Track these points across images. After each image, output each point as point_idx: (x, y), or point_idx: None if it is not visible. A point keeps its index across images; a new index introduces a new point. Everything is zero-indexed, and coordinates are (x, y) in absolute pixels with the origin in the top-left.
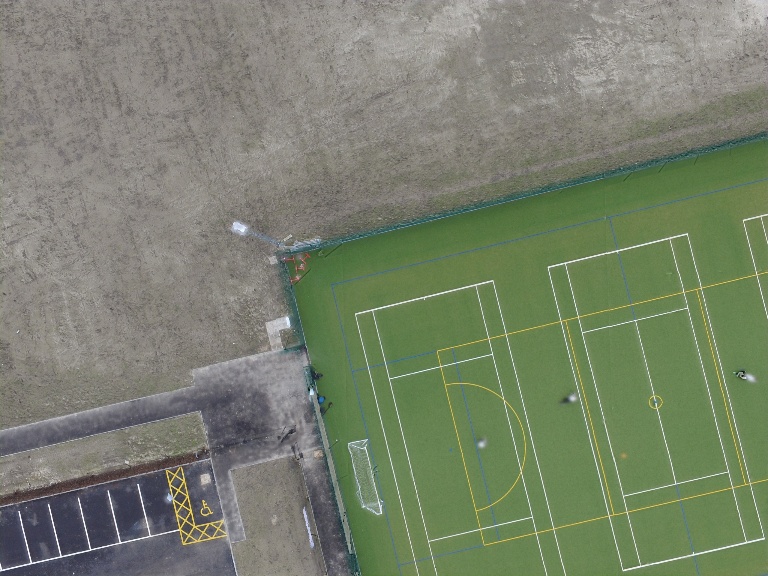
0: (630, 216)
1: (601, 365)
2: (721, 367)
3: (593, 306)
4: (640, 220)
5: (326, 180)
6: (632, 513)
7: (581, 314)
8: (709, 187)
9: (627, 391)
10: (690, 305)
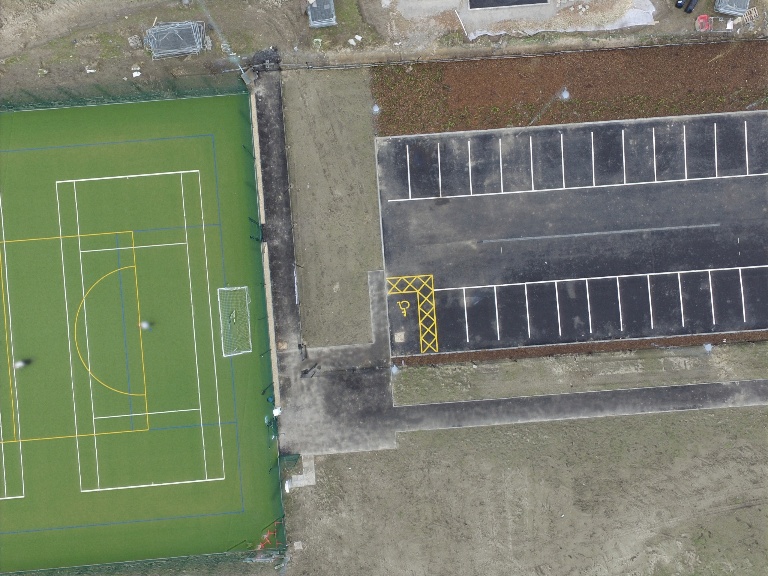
0: None
1: None
2: None
3: None
4: None
5: None
6: None
7: None
8: None
9: None
10: None
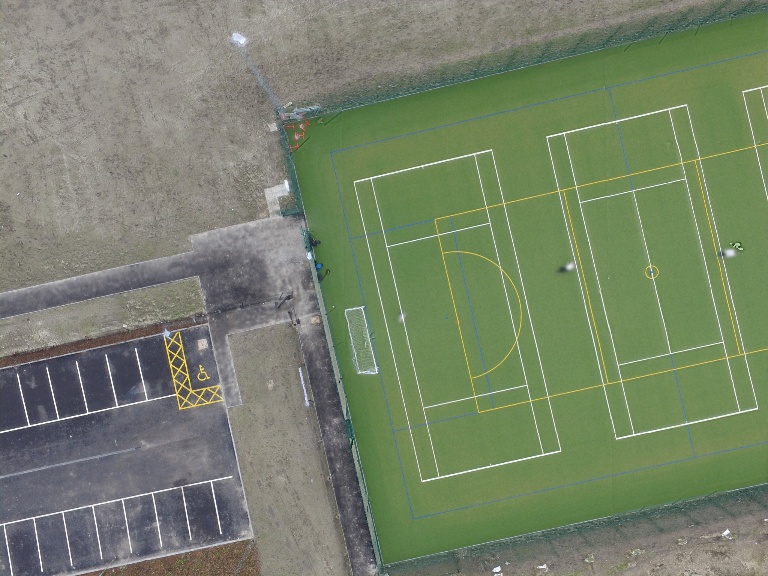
0: (630, 86)
1: (598, 235)
2: (718, 238)
3: (591, 176)
4: (640, 91)
5: (327, 47)
6: (626, 382)
7: (579, 184)
8: (709, 58)
9: (624, 261)
10: (688, 176)
